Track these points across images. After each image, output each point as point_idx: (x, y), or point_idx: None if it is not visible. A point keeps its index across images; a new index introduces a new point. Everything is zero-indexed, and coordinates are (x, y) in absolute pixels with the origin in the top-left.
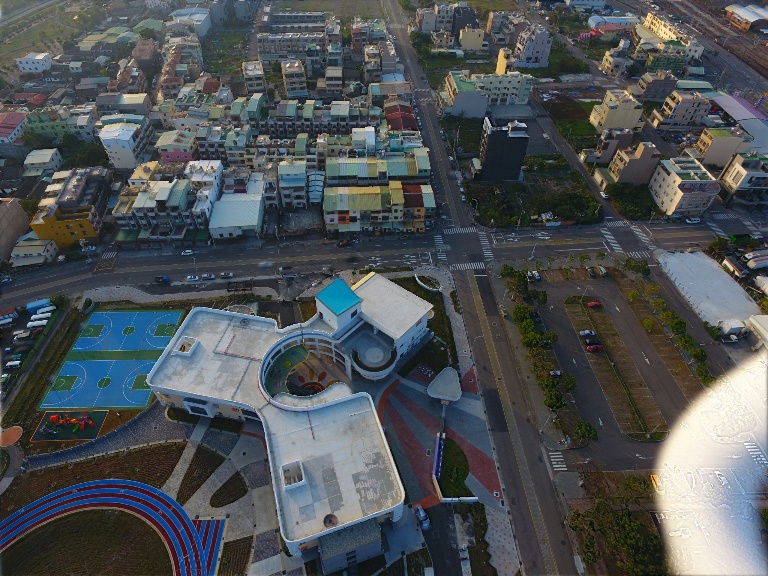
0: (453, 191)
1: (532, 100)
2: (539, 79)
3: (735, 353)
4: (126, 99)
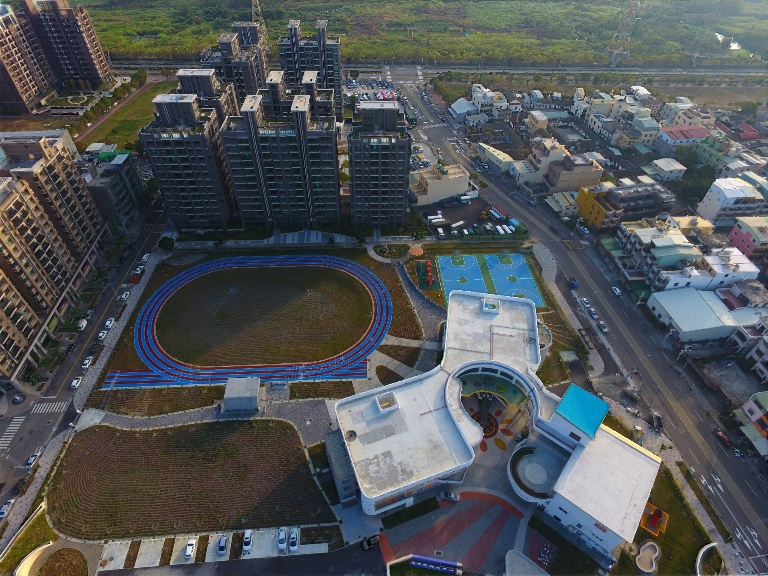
0: None
1: None
2: None
3: None
4: None
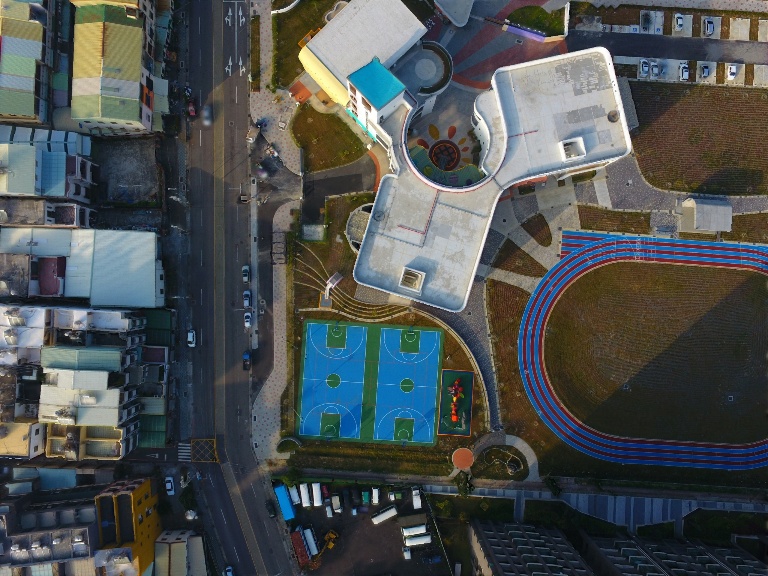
0: None
1: None
2: None
3: None
4: None
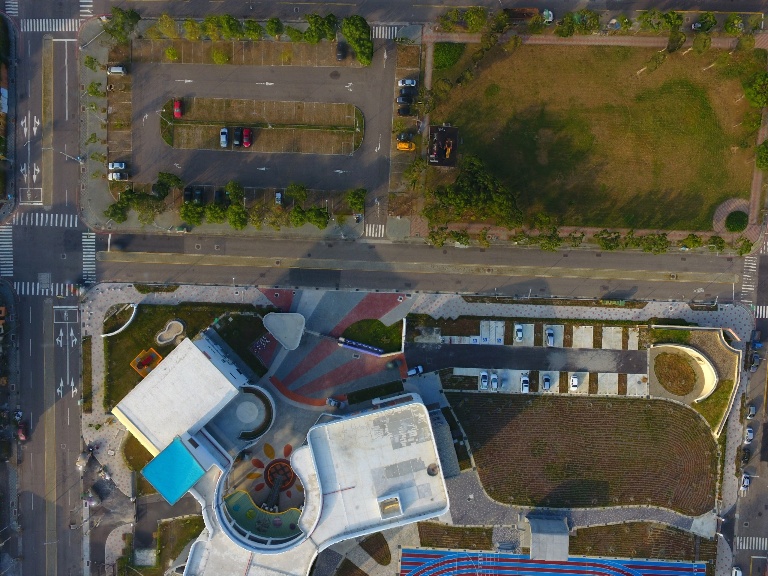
0: None
1: None
2: None
3: None
4: None
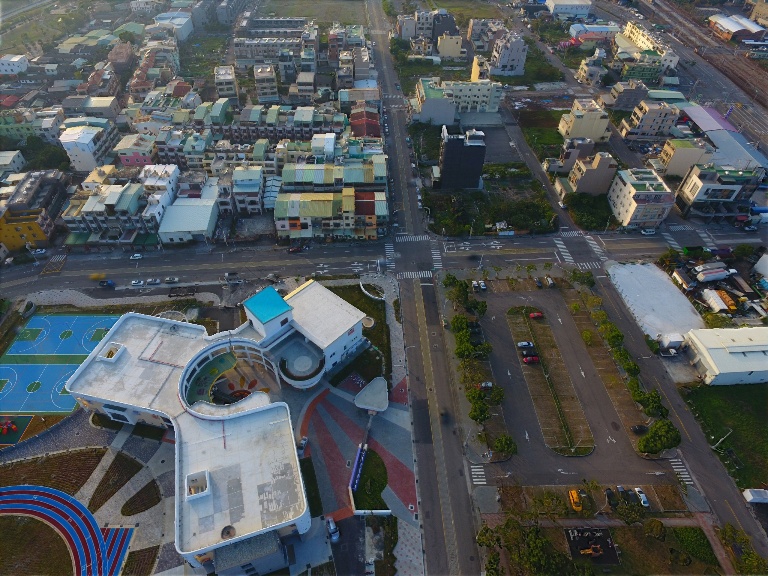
0: (411, 198)
1: (503, 108)
2: (513, 87)
3: (673, 367)
4: (93, 102)
